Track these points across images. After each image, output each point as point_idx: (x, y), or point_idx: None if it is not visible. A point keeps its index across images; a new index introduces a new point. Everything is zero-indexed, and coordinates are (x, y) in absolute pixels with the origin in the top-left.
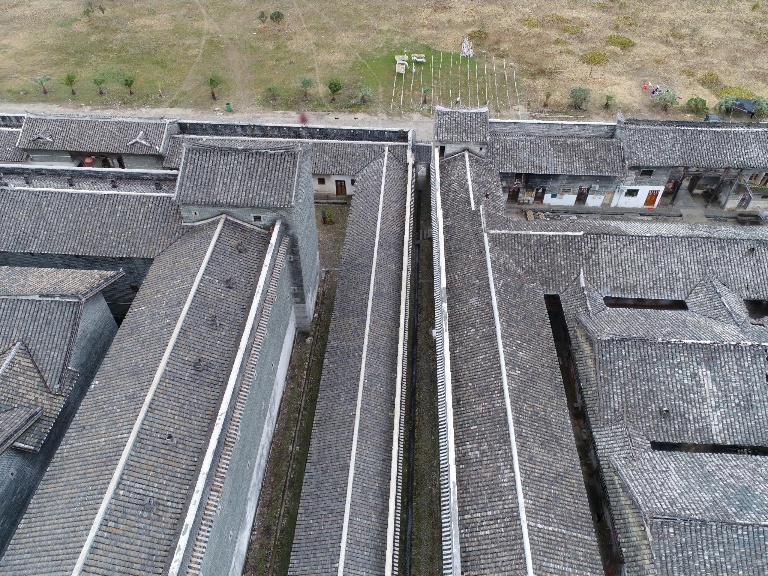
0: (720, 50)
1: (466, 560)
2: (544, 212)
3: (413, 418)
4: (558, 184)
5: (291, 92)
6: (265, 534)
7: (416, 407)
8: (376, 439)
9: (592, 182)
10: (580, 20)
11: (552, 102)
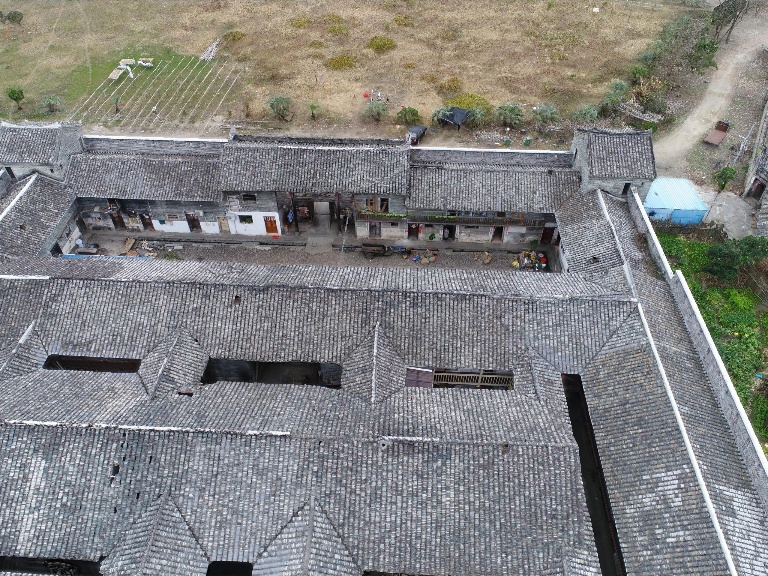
0: (485, 53)
1: None
2: (152, 240)
3: None
4: (160, 209)
5: None
6: None
7: None
8: None
9: (195, 207)
10: (356, 20)
11: (259, 112)
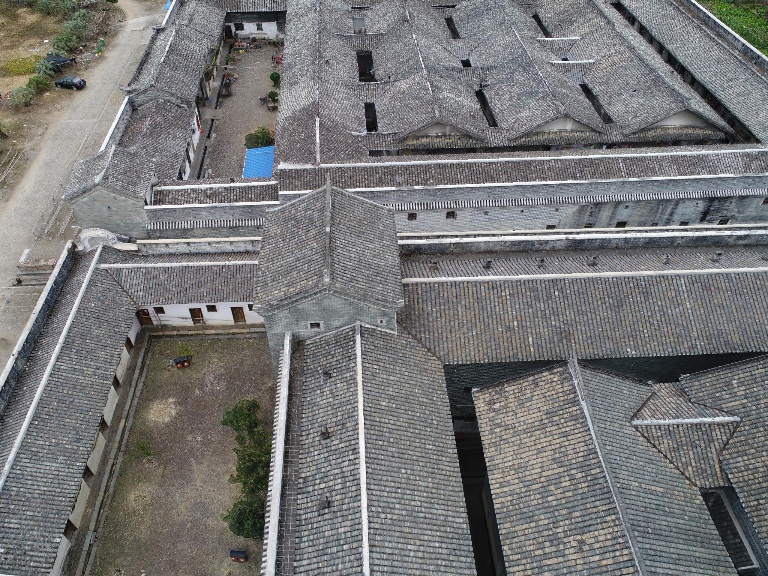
0: None
1: None
2: None
3: None
4: None
5: None
6: None
7: None
8: None
9: None
10: None
11: None
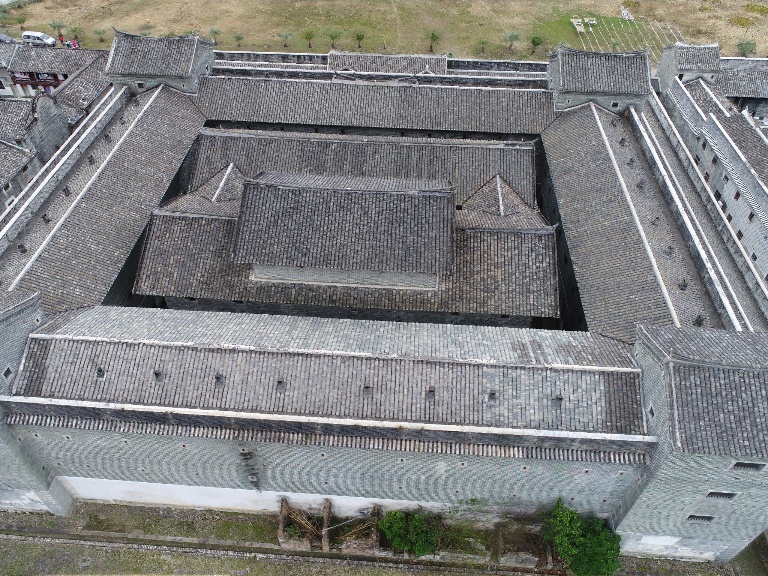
0: None
1: None
2: None
3: None
4: (767, 108)
5: (493, 47)
6: None
7: None
8: (724, 259)
9: None
10: None
11: None
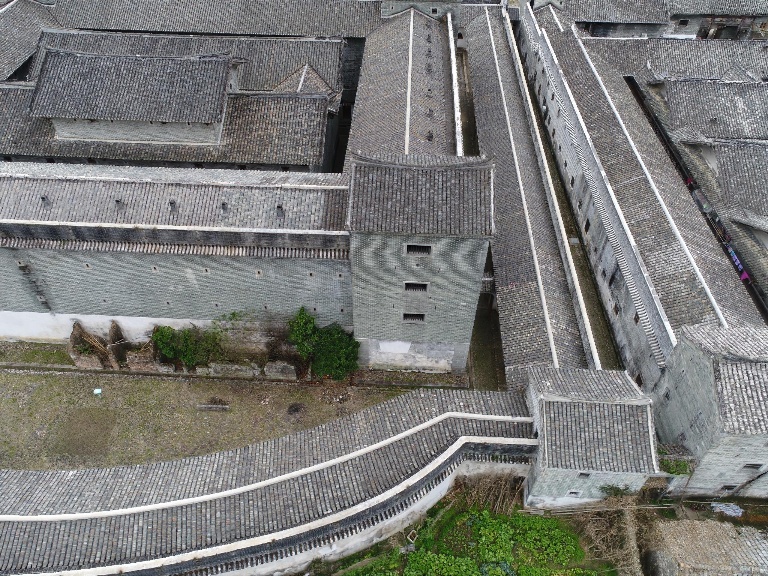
0: None
1: None
2: None
3: None
4: (616, 34)
5: None
6: None
7: None
8: (524, 145)
9: (642, 32)
10: None
11: None
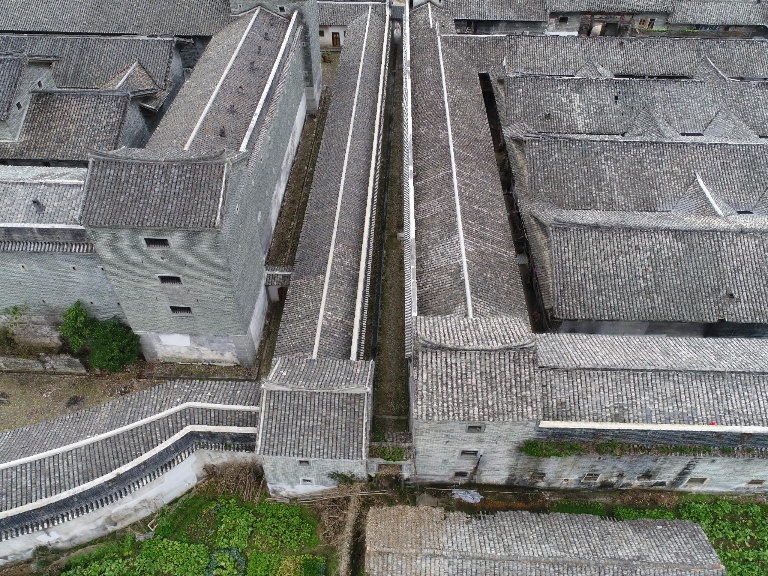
0: None
1: (417, 170)
2: None
3: (389, 155)
4: (499, 31)
5: None
6: (292, 203)
7: (391, 149)
8: (363, 141)
9: (524, 29)
10: None
11: None
